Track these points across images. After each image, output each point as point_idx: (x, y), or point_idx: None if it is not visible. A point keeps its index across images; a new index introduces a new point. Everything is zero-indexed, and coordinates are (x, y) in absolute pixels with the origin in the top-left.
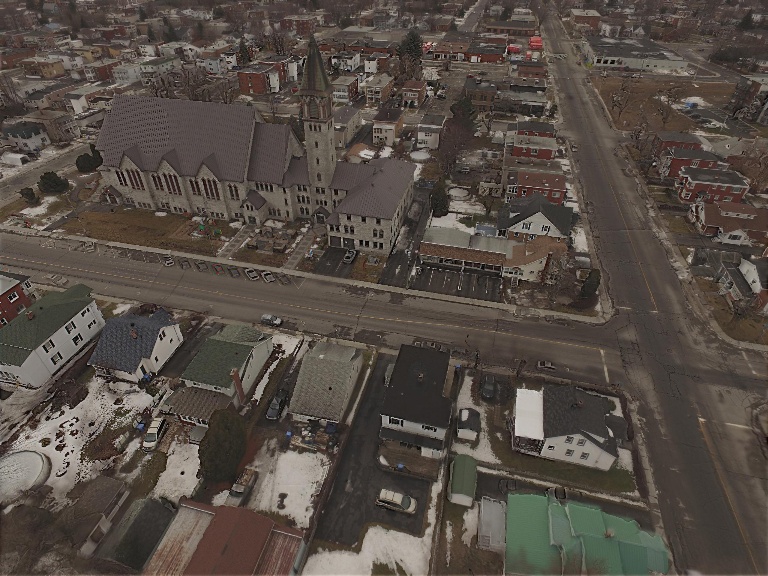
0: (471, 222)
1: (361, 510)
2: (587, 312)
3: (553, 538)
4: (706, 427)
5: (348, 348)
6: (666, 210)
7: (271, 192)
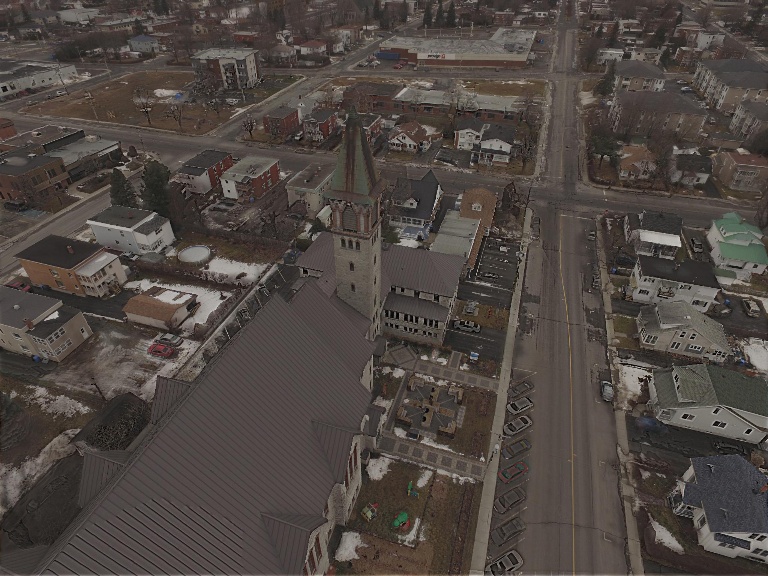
0: (389, 239)
1: (766, 325)
2: (522, 211)
3: (749, 241)
4: (612, 200)
5: (661, 306)
6: (377, 154)
7: (361, 379)
